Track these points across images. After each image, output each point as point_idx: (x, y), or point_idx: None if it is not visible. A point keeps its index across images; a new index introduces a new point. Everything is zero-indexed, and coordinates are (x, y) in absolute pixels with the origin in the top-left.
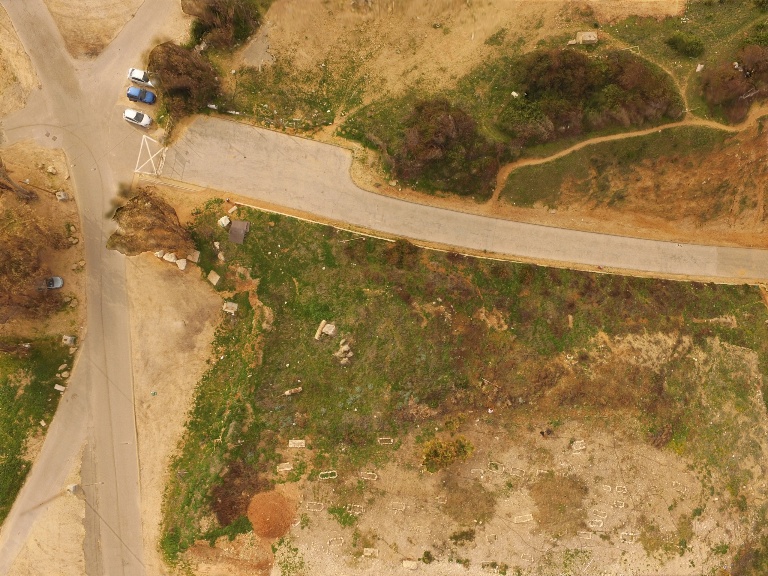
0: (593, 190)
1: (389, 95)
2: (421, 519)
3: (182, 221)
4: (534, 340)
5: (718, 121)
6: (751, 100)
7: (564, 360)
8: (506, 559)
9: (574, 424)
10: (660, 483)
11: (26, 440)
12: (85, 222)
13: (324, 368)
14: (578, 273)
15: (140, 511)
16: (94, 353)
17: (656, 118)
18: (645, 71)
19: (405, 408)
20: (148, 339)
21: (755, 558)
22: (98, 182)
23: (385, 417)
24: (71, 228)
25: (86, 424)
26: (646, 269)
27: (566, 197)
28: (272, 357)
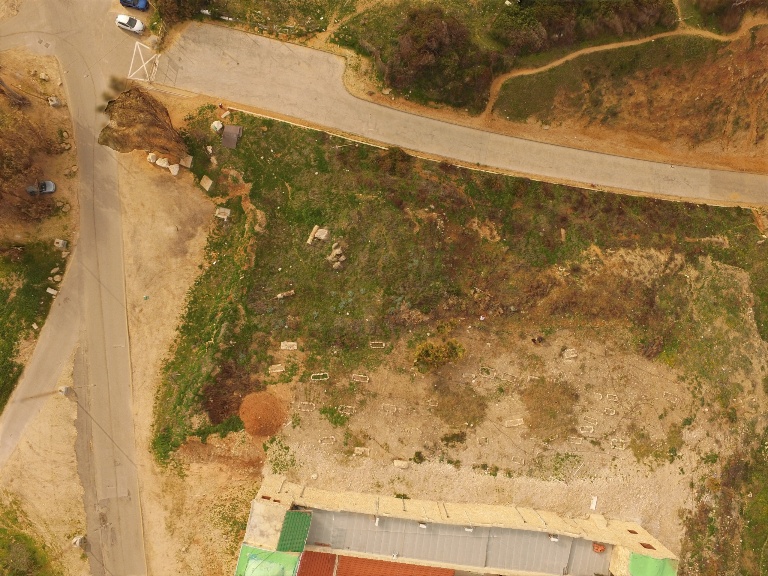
0: (586, 105)
1: (383, 3)
2: (412, 421)
3: (175, 125)
4: (526, 252)
5: (711, 30)
6: (744, 8)
7: (556, 272)
8: (497, 461)
9: (565, 333)
10: (651, 393)
11: (18, 343)
12: (78, 128)
13: (316, 272)
14: (571, 189)
15: (132, 413)
16: (86, 258)
17: (649, 26)
18: None
19: (397, 312)
20: (140, 244)
21: (745, 471)
22: (91, 88)
23: (377, 321)
24: (63, 134)
25: (78, 327)
26: (639, 189)
27: (559, 112)
28: (264, 260)
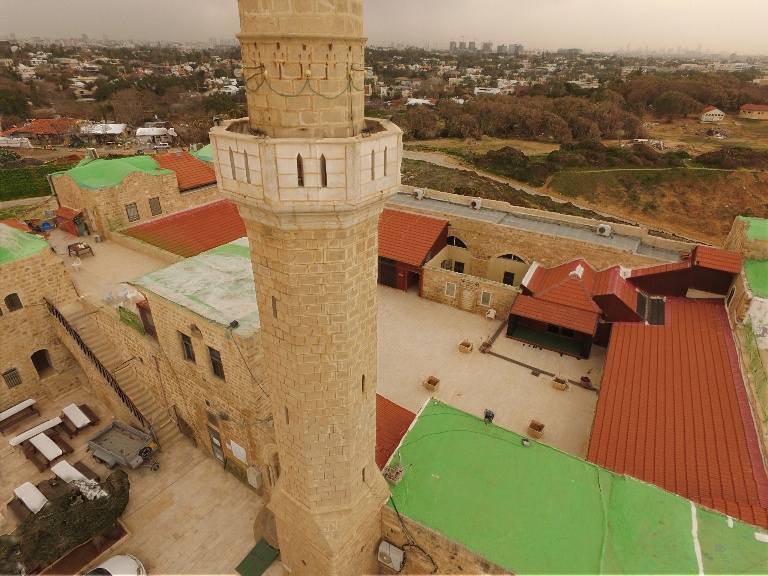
0: (626, 199)
1: None
2: None
3: None
4: None
5: None
6: None
7: None
8: None
9: None
10: None
11: None
12: None
13: None
14: None
15: None
16: None
17: (663, 163)
18: (647, 148)
19: None
20: None
21: None
22: None
23: None
24: None
25: None
26: None
27: (603, 199)
28: None
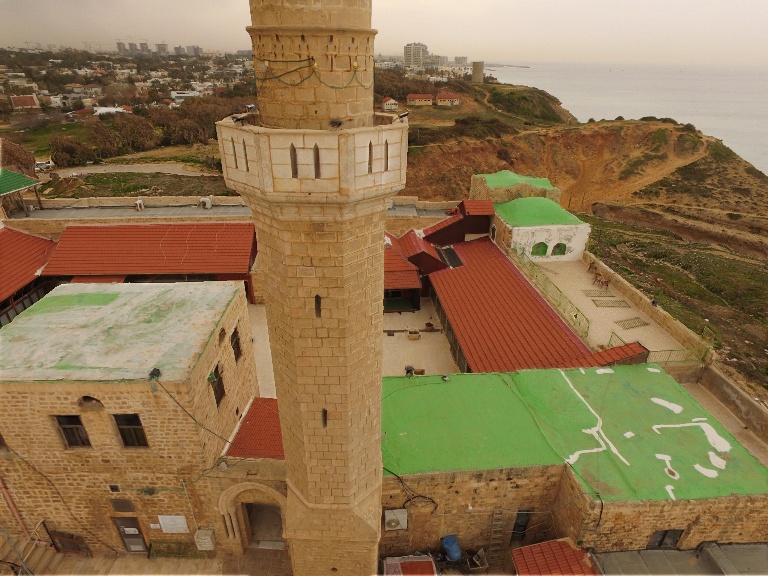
0: None
1: None
2: None
3: None
4: None
5: (414, 146)
6: None
7: None
8: None
9: None
10: None
11: None
12: None
13: None
14: None
15: None
16: None
17: None
18: None
19: None
20: None
21: None
22: None
23: None
24: None
25: None
26: None
27: None
28: None
